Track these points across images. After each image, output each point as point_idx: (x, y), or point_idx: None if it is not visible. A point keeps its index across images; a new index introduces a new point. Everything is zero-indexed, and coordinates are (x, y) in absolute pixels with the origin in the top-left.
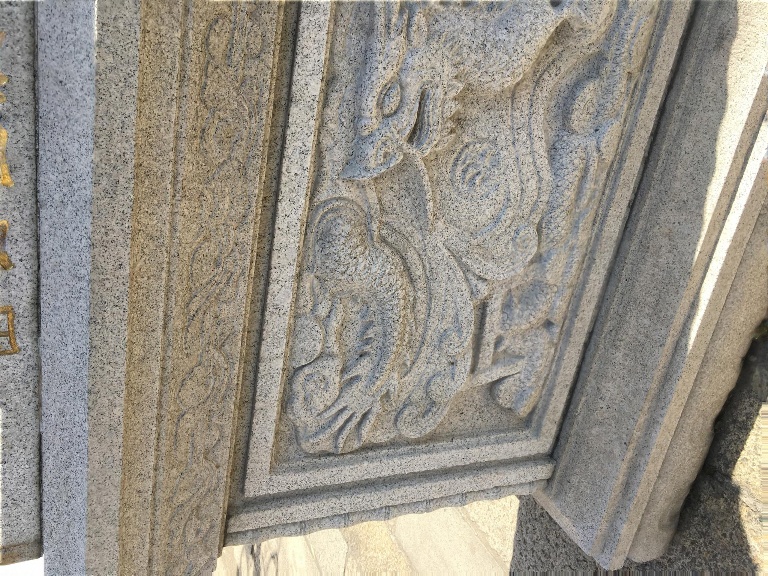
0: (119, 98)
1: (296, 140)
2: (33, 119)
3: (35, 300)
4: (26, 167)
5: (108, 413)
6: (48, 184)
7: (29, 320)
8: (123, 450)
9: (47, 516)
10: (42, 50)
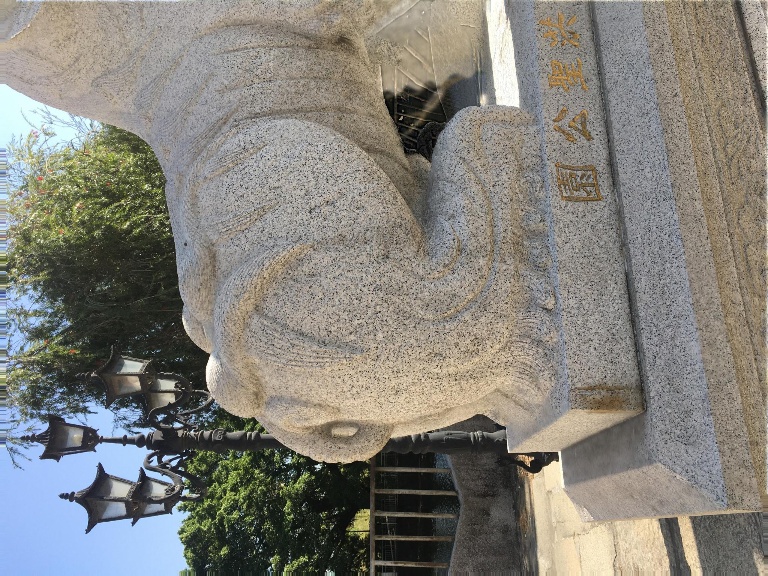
0: (655, 3)
1: (763, 60)
2: (595, 55)
3: (609, 162)
4: (594, 80)
5: (691, 205)
6: (612, 77)
7: (607, 176)
8: (710, 242)
9: (647, 344)
10: (599, 13)
